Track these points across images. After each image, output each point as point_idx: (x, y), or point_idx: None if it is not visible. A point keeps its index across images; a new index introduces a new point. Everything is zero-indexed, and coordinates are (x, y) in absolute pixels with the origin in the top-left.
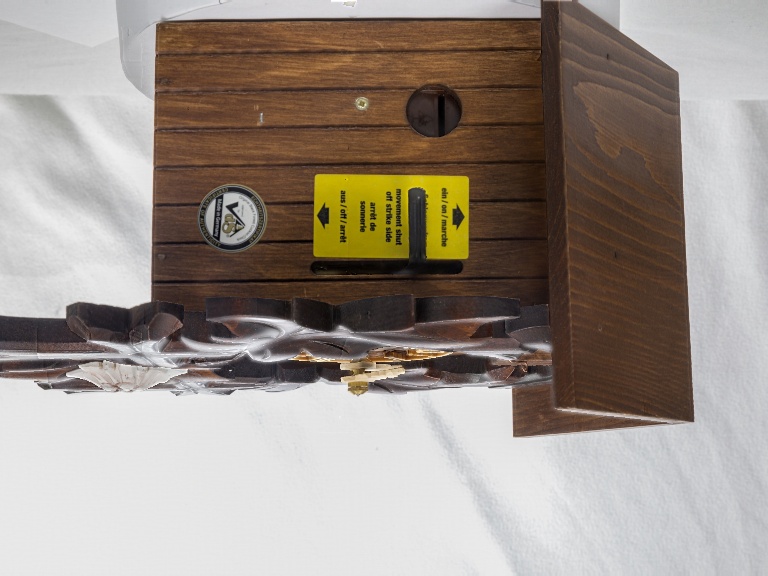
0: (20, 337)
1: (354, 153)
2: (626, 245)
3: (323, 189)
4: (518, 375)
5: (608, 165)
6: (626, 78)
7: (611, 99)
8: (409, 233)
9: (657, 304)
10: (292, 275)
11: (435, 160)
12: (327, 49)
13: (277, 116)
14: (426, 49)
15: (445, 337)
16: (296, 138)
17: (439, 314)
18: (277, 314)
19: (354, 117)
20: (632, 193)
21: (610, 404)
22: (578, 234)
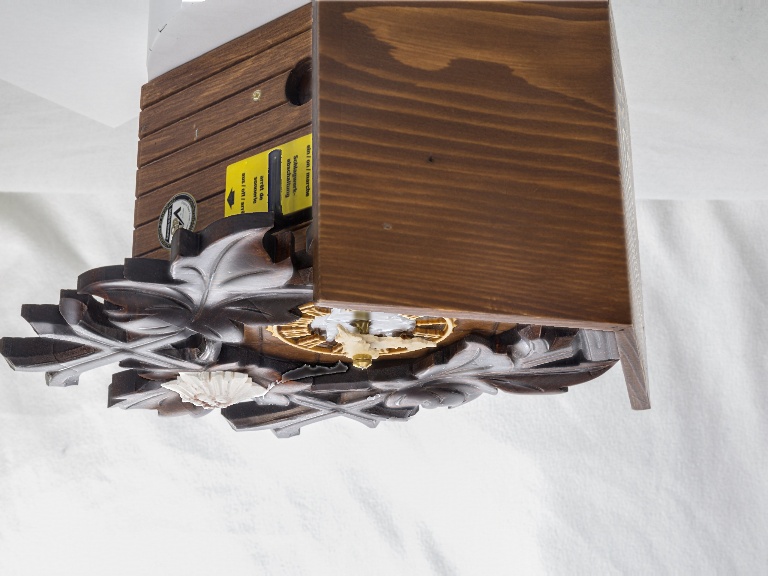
0: (42, 352)
1: (251, 139)
2: (458, 149)
3: (231, 176)
4: (570, 334)
5: (419, 77)
6: None
7: (431, 17)
8: (268, 190)
9: (535, 205)
10: None
11: (303, 123)
12: (237, 60)
13: (206, 128)
14: (300, 32)
15: (259, 268)
16: (216, 141)
17: (207, 240)
18: (122, 276)
19: (252, 109)
20: (477, 100)
21: (405, 299)
22: (343, 142)
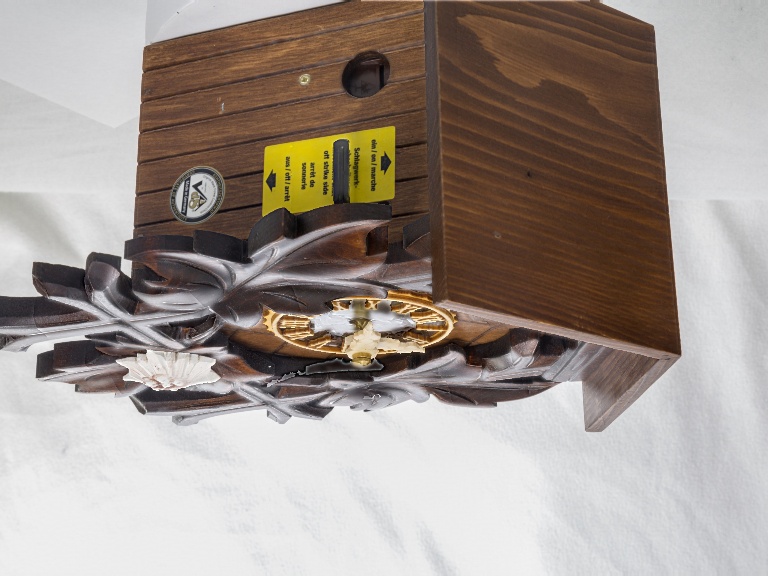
0: (19, 313)
1: (298, 123)
2: (549, 168)
3: (271, 158)
4: (555, 354)
5: (518, 92)
6: (553, 20)
7: (525, 35)
8: (333, 179)
9: (608, 231)
10: (244, 236)
11: (366, 117)
12: (277, 40)
13: (235, 103)
14: (360, 23)
15: (346, 258)
16: (250, 119)
17: (312, 225)
18: (185, 248)
19: (298, 92)
20: (562, 123)
21: (514, 308)
22: (460, 146)
